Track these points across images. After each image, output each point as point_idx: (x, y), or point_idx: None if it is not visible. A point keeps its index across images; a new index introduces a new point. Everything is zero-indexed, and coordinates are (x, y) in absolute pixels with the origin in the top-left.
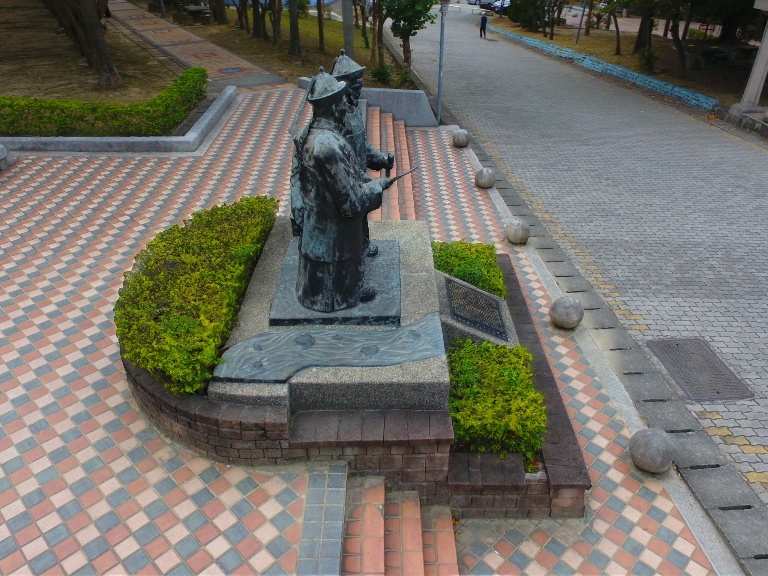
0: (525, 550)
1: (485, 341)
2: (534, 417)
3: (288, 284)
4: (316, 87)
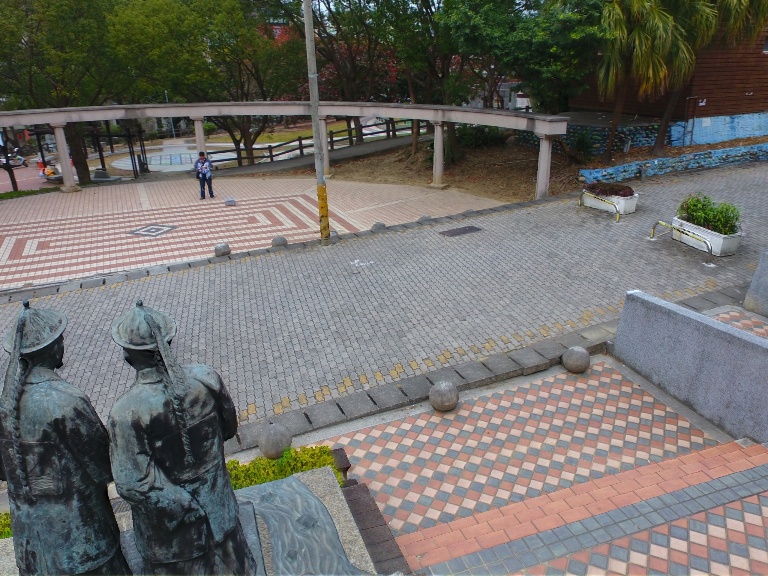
0: (381, 509)
1: None
2: (318, 450)
3: None
4: (159, 323)
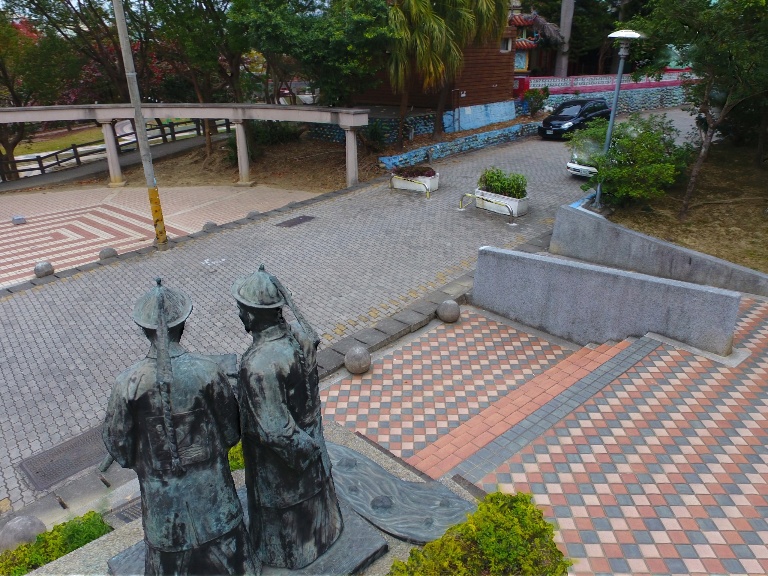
0: None
1: (232, 462)
2: None
3: (319, 572)
4: None
